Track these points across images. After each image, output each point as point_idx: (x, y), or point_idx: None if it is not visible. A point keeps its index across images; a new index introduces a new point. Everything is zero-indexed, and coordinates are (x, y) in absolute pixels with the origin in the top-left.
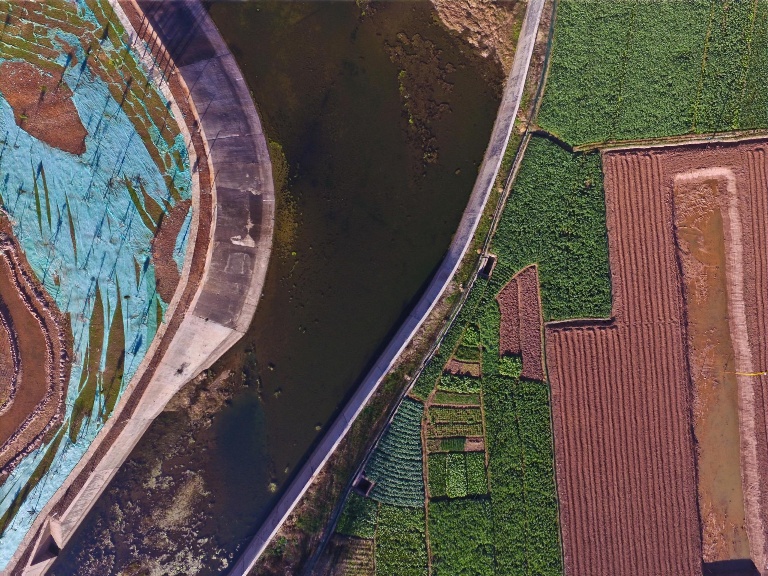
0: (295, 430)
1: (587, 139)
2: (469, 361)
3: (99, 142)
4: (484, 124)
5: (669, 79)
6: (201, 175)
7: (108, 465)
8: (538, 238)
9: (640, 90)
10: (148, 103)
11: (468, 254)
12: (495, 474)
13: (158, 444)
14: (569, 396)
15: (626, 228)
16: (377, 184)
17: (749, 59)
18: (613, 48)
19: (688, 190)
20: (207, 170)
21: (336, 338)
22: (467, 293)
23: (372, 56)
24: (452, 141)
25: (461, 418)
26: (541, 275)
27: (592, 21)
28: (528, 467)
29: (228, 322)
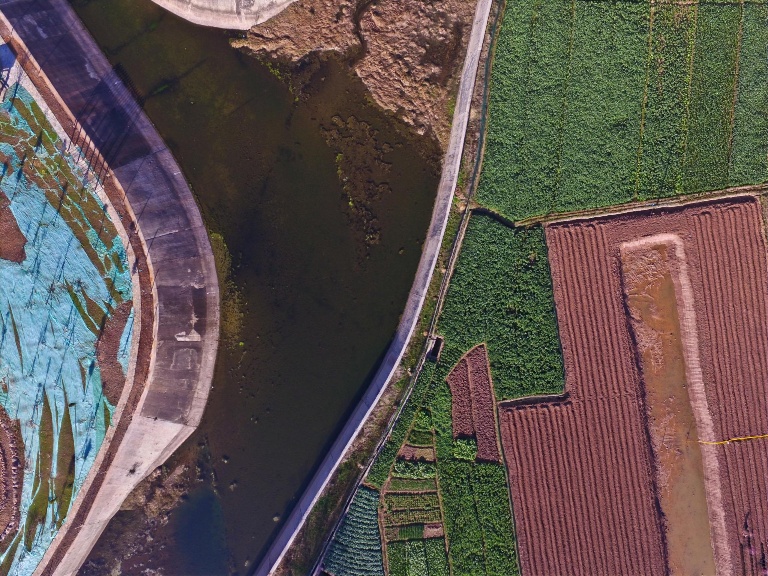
0: (253, 522)
1: (528, 214)
2: (422, 446)
3: (39, 249)
4: (425, 201)
5: (607, 148)
6: (141, 276)
7: (65, 571)
8: (484, 317)
9: (578, 161)
10: (85, 207)
11: (415, 337)
12: (456, 560)
13: (116, 544)
14: (527, 476)
15: (574, 301)
16: (321, 269)
17: (688, 122)
18: (548, 120)
19: (636, 257)
20: (147, 270)
21: (289, 426)
22: (416, 376)
23: (308, 141)
24: (394, 221)
25: (418, 504)
26: (490, 354)
27: (525, 95)
28: (489, 551)
29: (178, 418)
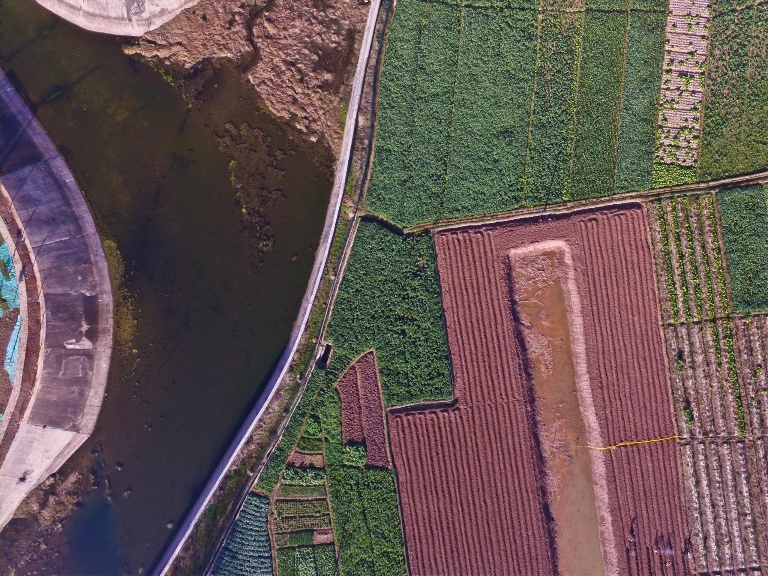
0: (147, 529)
1: (416, 221)
2: (312, 452)
3: None
4: (319, 208)
5: (495, 155)
6: (27, 283)
7: None
8: (372, 324)
9: (466, 168)
10: None
11: (304, 344)
12: (345, 566)
13: (10, 552)
14: (415, 482)
15: (462, 308)
16: (215, 275)
17: (575, 129)
18: (436, 128)
19: (526, 263)
20: (33, 278)
21: (183, 433)
22: (306, 383)
23: (202, 148)
24: (287, 227)
25: (307, 511)
26: (378, 361)
27: (413, 102)
28: (378, 557)
29: (69, 426)
